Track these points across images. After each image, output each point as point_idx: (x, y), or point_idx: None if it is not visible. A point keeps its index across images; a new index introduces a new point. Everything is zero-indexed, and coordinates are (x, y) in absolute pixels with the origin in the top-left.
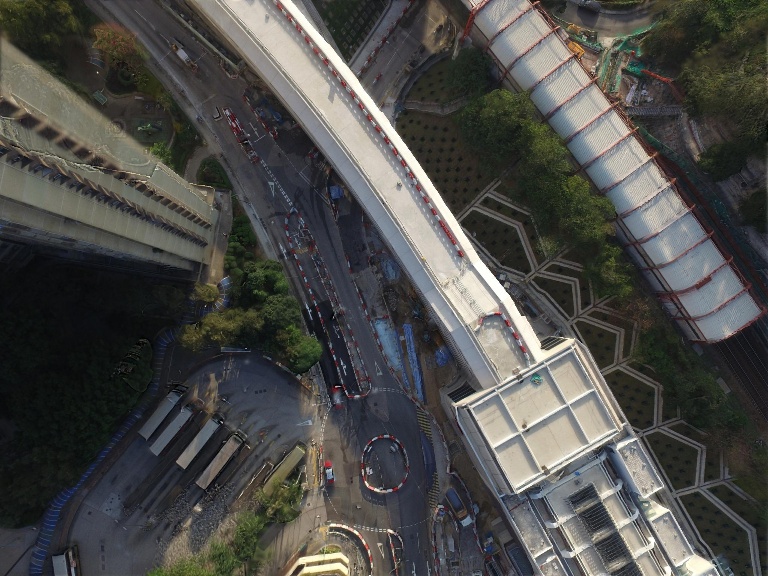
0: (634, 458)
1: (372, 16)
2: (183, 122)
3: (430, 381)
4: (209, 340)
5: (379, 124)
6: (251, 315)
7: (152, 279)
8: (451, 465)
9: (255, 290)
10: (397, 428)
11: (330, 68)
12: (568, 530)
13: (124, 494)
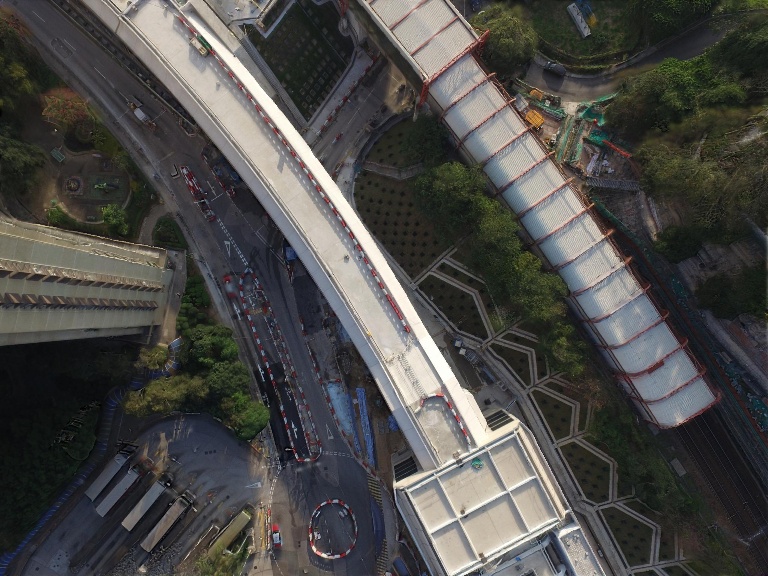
0: (577, 546)
1: (333, 75)
2: (140, 181)
3: (382, 446)
4: (150, 410)
5: (328, 195)
6: (195, 384)
7: (96, 347)
8: (401, 532)
9: (201, 358)
10: (347, 493)
11: (279, 138)
12: None
13: (71, 552)
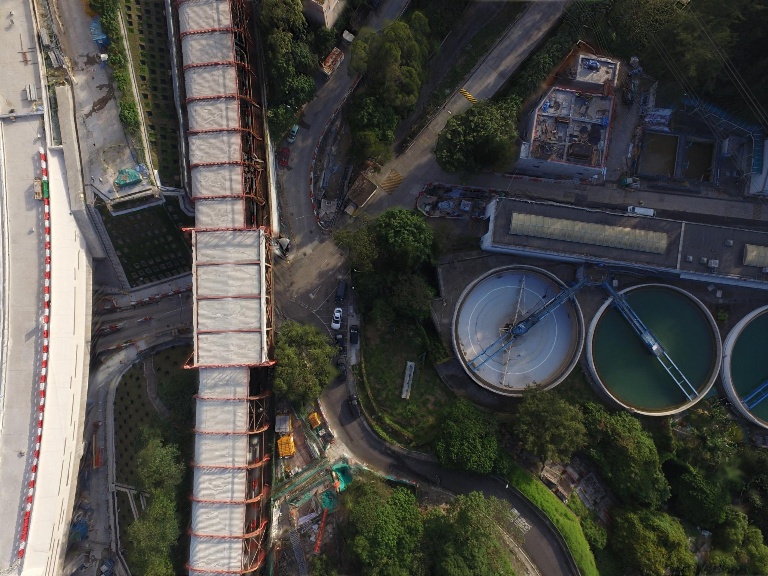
0: None
1: (179, 267)
2: None
3: None
4: None
5: (46, 391)
6: None
7: None
8: None
9: None
10: None
11: (44, 314)
12: None
13: None
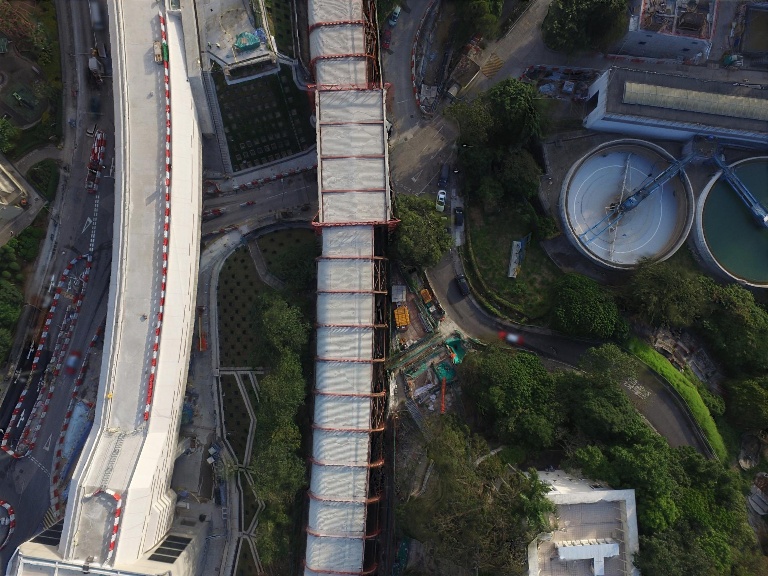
0: None
1: (282, 150)
2: (54, 117)
3: None
4: None
5: (169, 253)
6: None
7: None
8: None
9: None
10: (22, 506)
11: (166, 176)
12: None
13: None
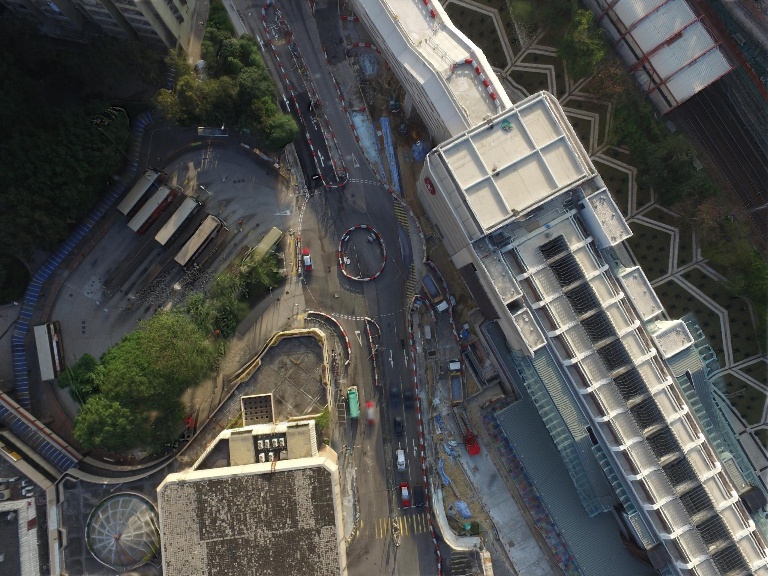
0: (603, 209)
1: None
2: None
3: (407, 175)
4: (184, 96)
5: None
6: (226, 79)
7: (127, 36)
8: (428, 256)
9: (230, 57)
10: (374, 219)
11: None
12: (538, 281)
13: (105, 276)
